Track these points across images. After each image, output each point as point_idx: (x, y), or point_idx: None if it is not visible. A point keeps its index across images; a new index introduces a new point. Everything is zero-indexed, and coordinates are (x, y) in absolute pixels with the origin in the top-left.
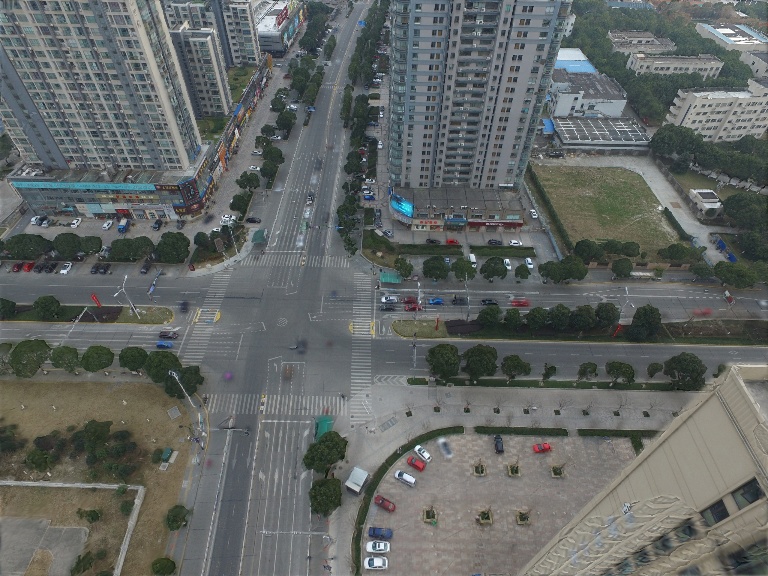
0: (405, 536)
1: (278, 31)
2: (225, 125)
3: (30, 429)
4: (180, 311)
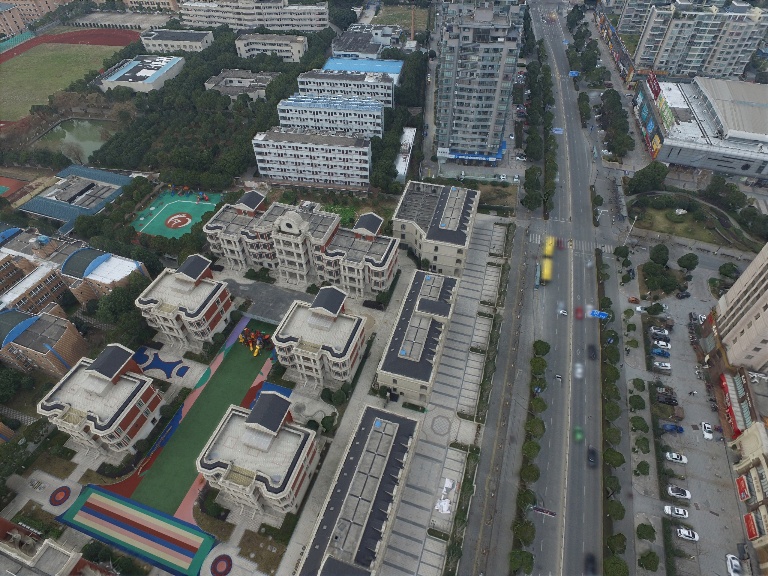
0: None
1: None
2: None
3: None
4: (577, 2)
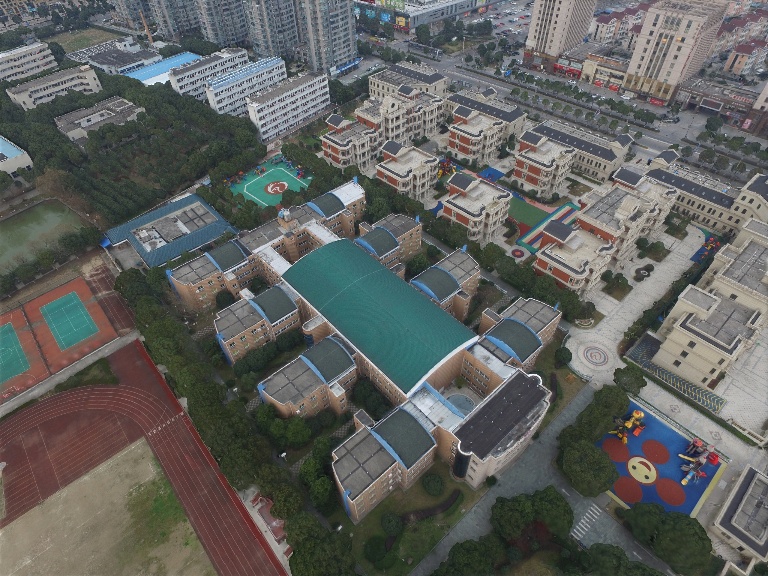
0: None
1: None
2: None
3: None
4: None
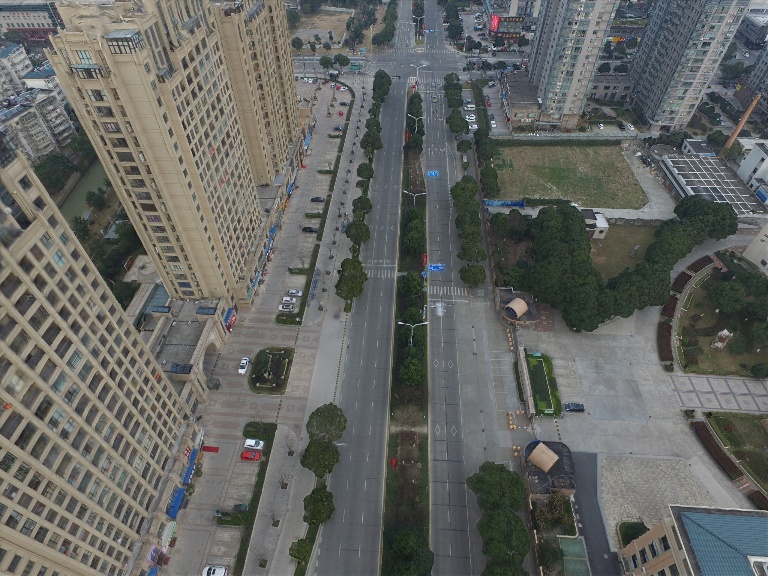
0: None
1: (766, 24)
2: None
3: None
4: None
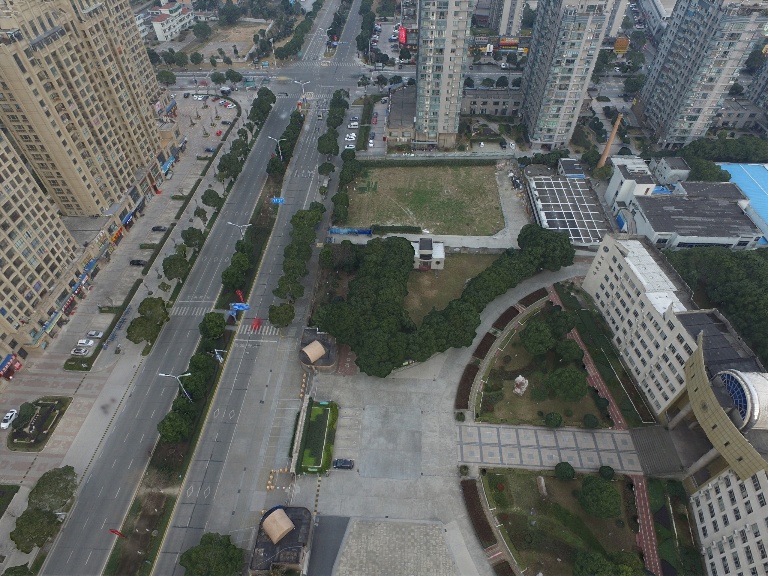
0: (202, 103)
1: None
2: (481, 34)
3: (278, 44)
4: (330, 58)
